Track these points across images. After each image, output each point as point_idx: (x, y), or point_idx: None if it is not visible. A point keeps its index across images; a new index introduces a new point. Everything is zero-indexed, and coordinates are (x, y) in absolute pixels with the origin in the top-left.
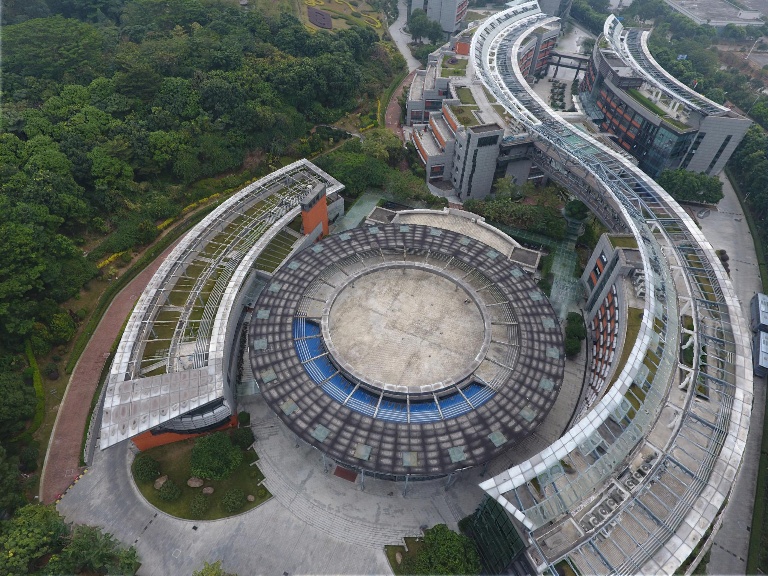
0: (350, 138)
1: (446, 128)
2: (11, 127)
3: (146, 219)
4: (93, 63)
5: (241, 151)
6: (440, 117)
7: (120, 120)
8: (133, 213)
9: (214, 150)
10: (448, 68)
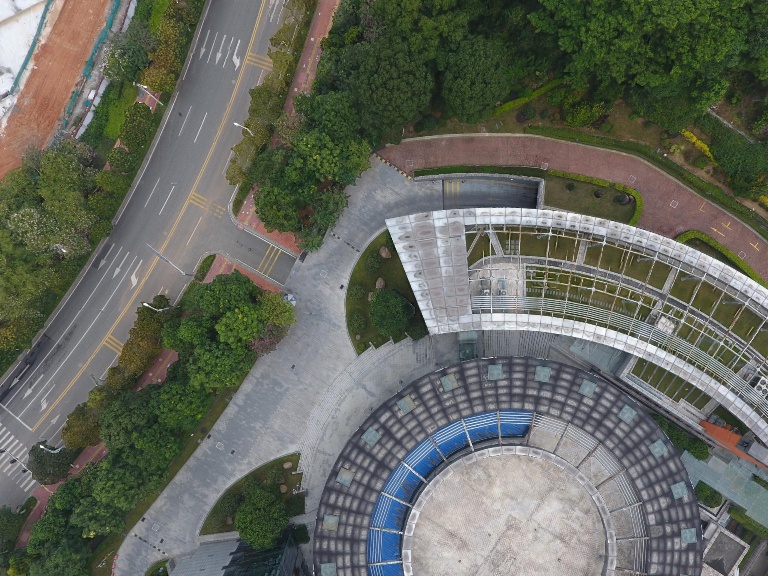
0: None
1: None
2: None
3: None
4: None
5: None
6: None
7: None
8: None
9: None
10: None
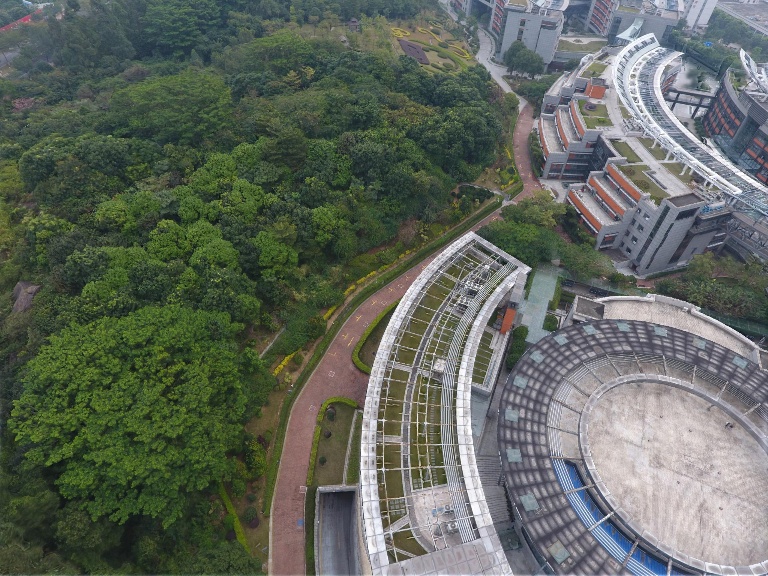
0: (493, 197)
1: (614, 191)
2: (164, 209)
3: (313, 311)
4: (229, 124)
5: (396, 222)
6: (601, 176)
7: (271, 193)
8: (299, 305)
9: (373, 224)
10: (589, 116)
